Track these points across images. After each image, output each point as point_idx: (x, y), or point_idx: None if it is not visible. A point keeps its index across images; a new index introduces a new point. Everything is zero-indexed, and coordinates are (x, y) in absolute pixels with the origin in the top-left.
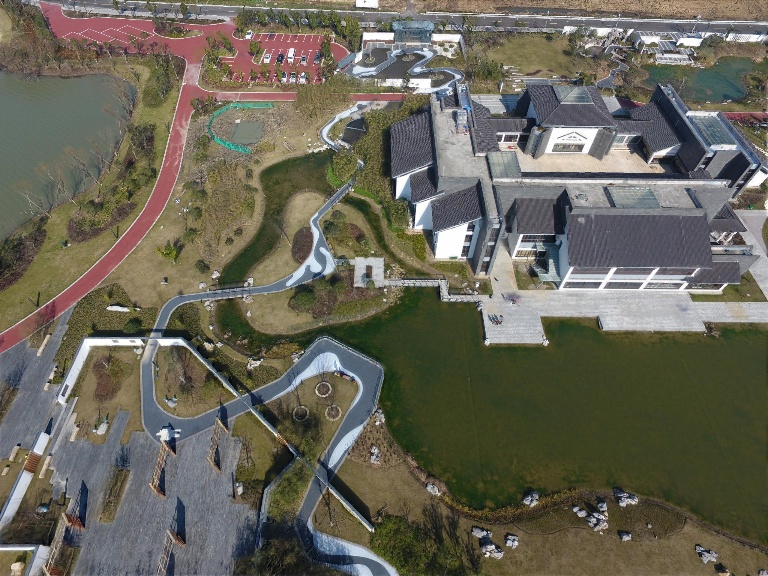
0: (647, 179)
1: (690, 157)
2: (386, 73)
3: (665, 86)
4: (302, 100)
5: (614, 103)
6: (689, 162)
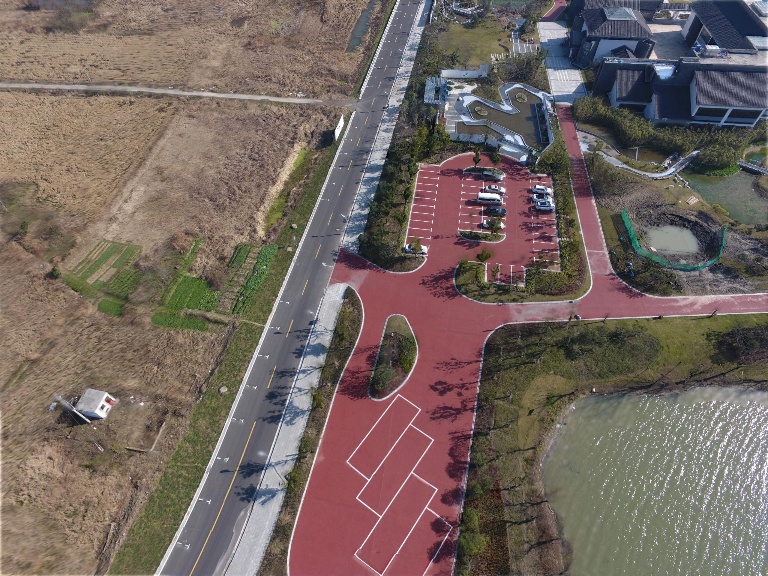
0: (744, 1)
1: (650, 2)
2: (517, 128)
3: (513, 3)
4: (590, 192)
5: (549, 24)
6: (651, 5)
